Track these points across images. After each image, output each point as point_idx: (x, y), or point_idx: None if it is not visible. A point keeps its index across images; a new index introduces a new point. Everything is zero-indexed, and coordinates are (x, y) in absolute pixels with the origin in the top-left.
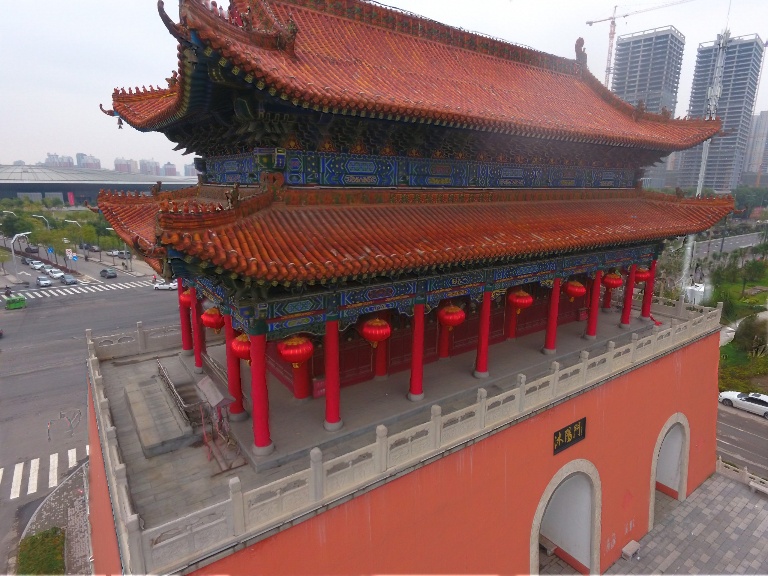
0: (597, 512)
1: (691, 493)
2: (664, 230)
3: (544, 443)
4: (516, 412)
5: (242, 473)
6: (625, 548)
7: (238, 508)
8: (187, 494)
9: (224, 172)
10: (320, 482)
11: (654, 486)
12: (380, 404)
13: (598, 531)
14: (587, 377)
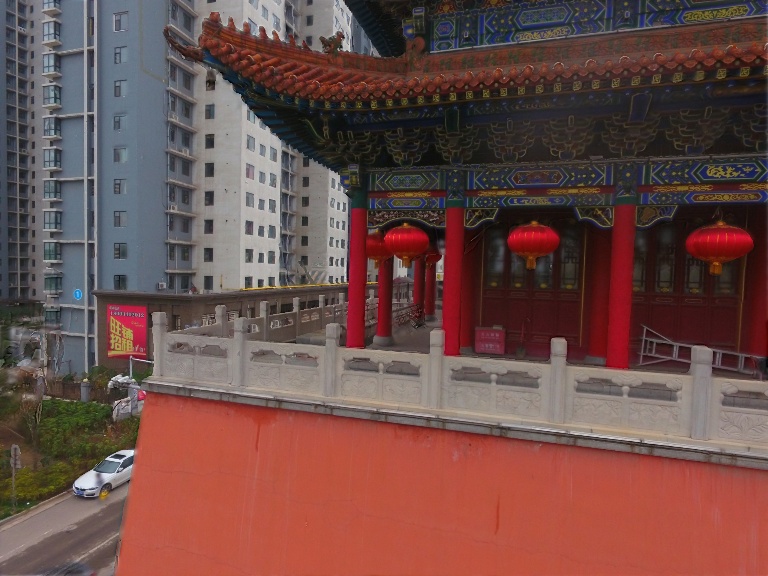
0: None
1: None
2: None
3: None
4: None
5: None
6: None
7: None
8: None
9: None
10: None
11: None
12: None
13: None
14: None
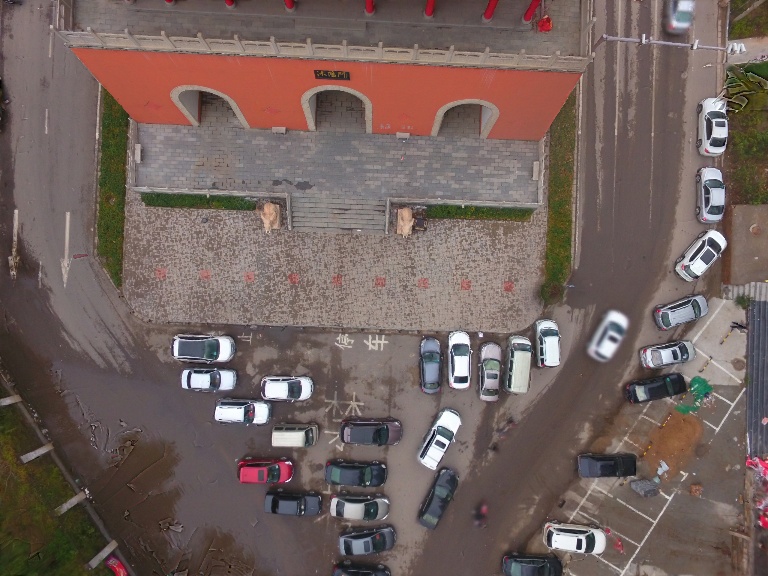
0: (368, 112)
1: (495, 139)
2: None
3: (305, 71)
4: (273, 52)
5: (122, 5)
6: (399, 133)
7: (96, 37)
8: (96, 5)
9: None
10: (135, 41)
11: (440, 122)
12: None
13: (370, 118)
14: (351, 54)
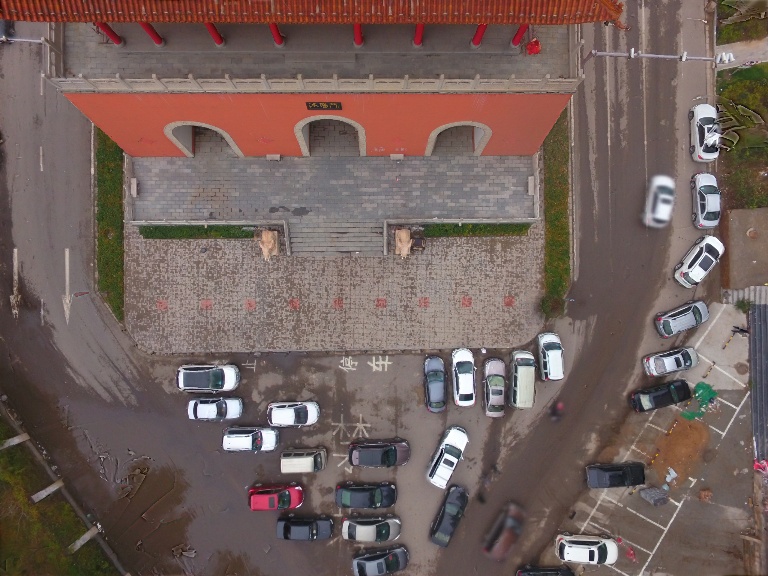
0: (361, 137)
1: (489, 156)
2: (466, 18)
3: (297, 104)
4: (265, 88)
5: (112, 49)
6: (393, 155)
7: None
8: (86, 49)
9: None
10: None
11: (433, 143)
12: (197, 36)
13: (363, 143)
14: (342, 86)
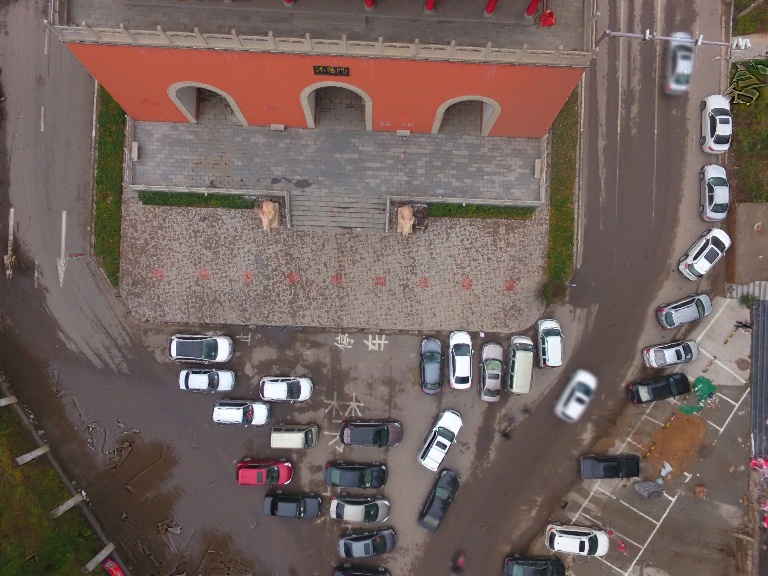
0: (368, 109)
1: (496, 136)
2: None
3: (304, 67)
4: (271, 47)
5: None
6: (399, 130)
7: (91, 32)
8: None
9: None
10: (130, 36)
11: (441, 119)
12: None
13: (370, 116)
14: (351, 49)
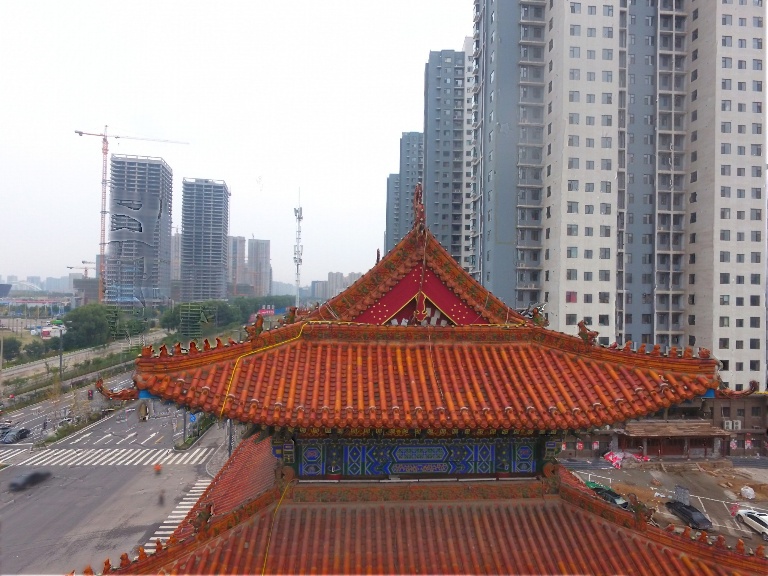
0: None
1: None
2: None
3: None
4: None
5: None
6: None
7: None
8: None
9: (391, 461)
10: None
11: None
12: None
13: None
14: None
